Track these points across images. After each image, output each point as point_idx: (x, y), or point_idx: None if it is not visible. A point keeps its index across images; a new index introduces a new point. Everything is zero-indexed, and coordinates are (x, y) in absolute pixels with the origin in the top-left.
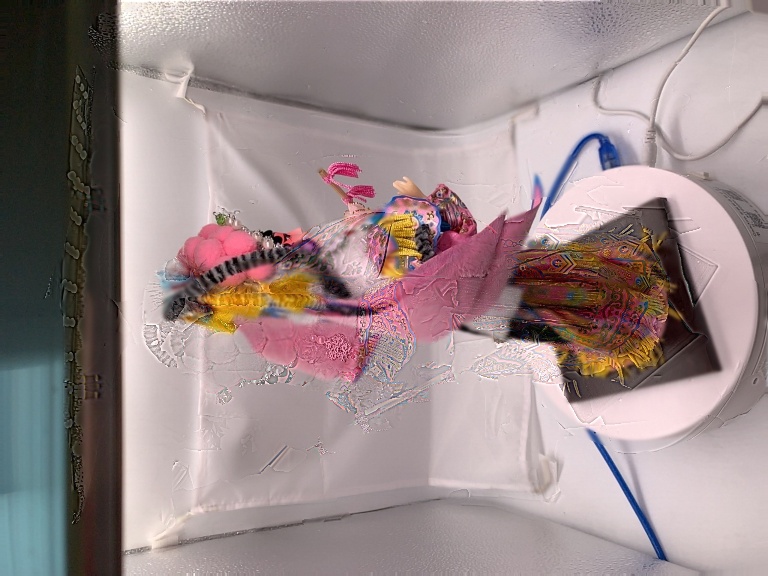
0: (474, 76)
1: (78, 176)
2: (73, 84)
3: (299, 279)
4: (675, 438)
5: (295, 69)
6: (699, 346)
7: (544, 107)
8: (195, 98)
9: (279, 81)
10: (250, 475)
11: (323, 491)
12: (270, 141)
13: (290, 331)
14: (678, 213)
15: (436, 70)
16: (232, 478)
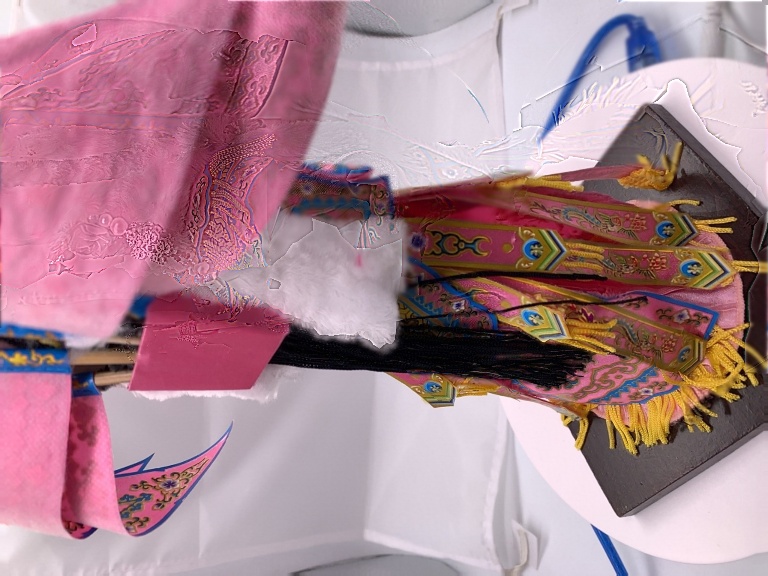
0: None
1: None
2: None
3: (66, 124)
4: None
5: None
6: None
7: None
8: None
9: None
10: None
11: None
12: None
13: (27, 236)
14: None
15: None
16: None
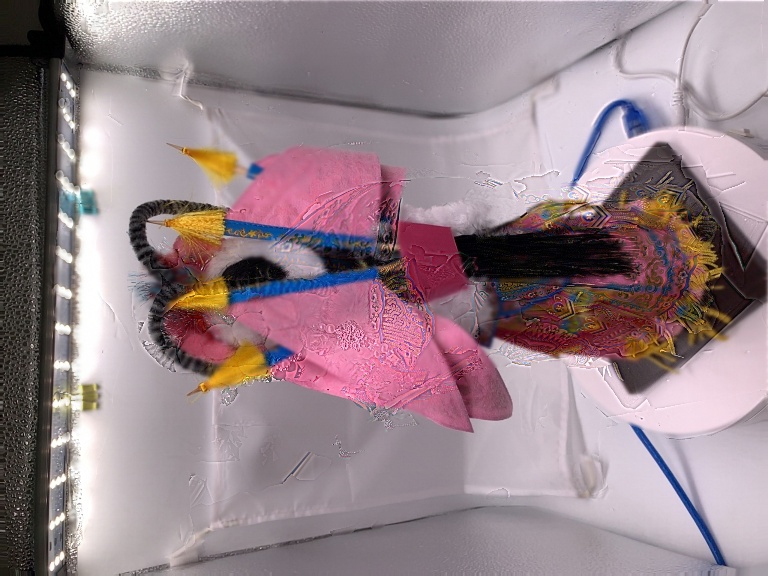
0: (482, 49)
1: (66, 175)
2: (58, 82)
3: (301, 262)
4: (733, 418)
5: (293, 56)
6: (753, 313)
7: (560, 76)
8: (192, 95)
9: (277, 70)
10: (272, 486)
11: (351, 499)
12: (272, 134)
13: (294, 319)
14: (718, 169)
15: (441, 46)
16: (253, 490)
